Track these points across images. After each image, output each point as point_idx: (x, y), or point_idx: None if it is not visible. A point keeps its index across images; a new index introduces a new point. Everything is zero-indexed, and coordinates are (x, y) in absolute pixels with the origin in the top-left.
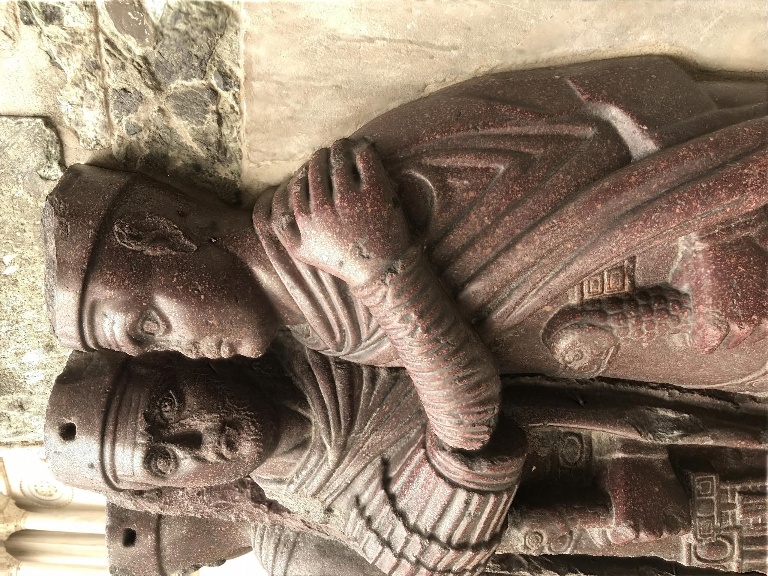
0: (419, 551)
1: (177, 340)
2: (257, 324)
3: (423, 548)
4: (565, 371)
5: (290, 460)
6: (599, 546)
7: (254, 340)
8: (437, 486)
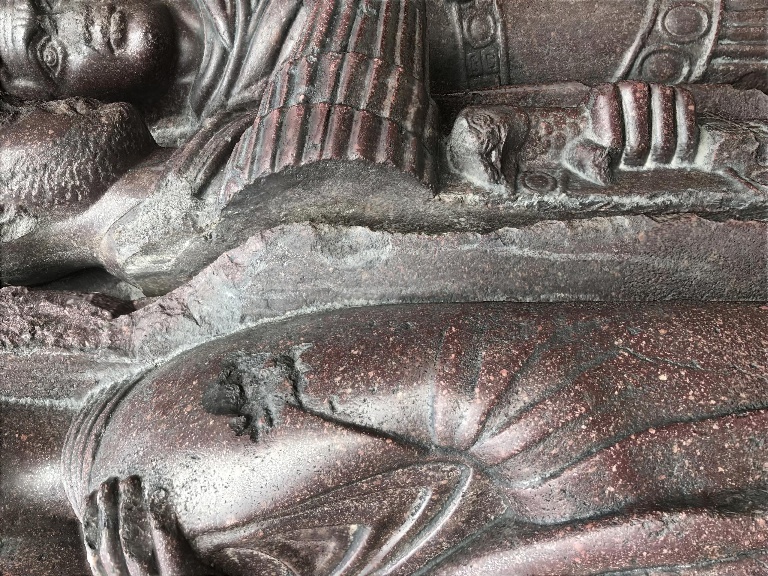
0: (306, 77)
1: (72, 8)
2: (153, 8)
3: (310, 66)
4: (467, 43)
5: (159, 168)
6: (600, 181)
7: (147, 15)
8: (320, 4)
